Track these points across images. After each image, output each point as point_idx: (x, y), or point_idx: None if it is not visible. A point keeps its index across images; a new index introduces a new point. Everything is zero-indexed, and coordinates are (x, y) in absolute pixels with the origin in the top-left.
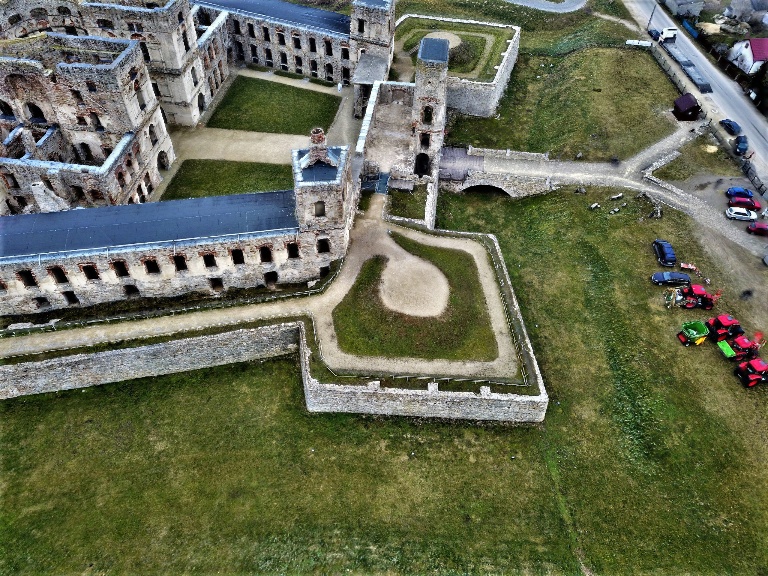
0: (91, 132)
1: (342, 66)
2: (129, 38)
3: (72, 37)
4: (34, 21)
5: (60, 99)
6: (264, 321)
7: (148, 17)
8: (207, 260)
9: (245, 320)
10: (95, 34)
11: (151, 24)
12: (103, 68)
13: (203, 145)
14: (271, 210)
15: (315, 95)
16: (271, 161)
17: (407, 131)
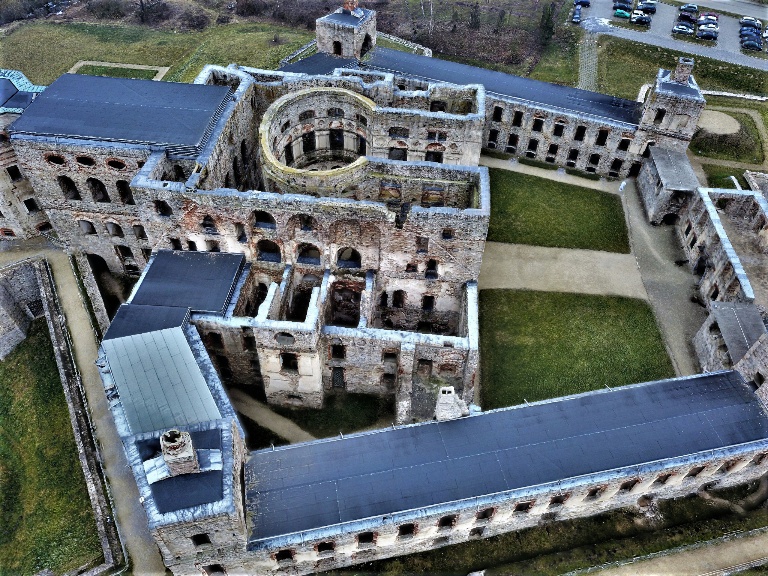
0: (419, 280)
1: (615, 157)
2: (424, 147)
3: (401, 163)
4: (300, 126)
5: (396, 246)
6: (758, 568)
7: (459, 125)
8: (657, 478)
9: (733, 567)
10: (380, 142)
11: (460, 133)
12: (477, 214)
13: (491, 267)
14: (733, 408)
15: (585, 192)
16: (586, 290)
17: (756, 253)
